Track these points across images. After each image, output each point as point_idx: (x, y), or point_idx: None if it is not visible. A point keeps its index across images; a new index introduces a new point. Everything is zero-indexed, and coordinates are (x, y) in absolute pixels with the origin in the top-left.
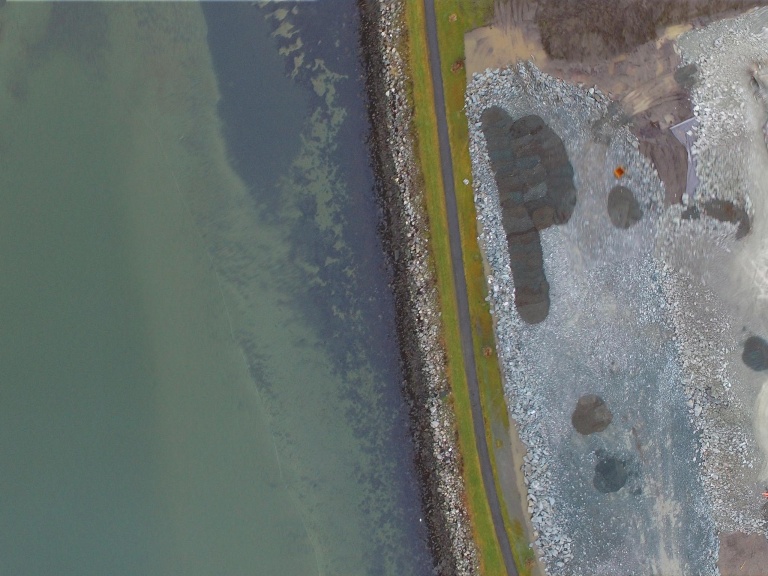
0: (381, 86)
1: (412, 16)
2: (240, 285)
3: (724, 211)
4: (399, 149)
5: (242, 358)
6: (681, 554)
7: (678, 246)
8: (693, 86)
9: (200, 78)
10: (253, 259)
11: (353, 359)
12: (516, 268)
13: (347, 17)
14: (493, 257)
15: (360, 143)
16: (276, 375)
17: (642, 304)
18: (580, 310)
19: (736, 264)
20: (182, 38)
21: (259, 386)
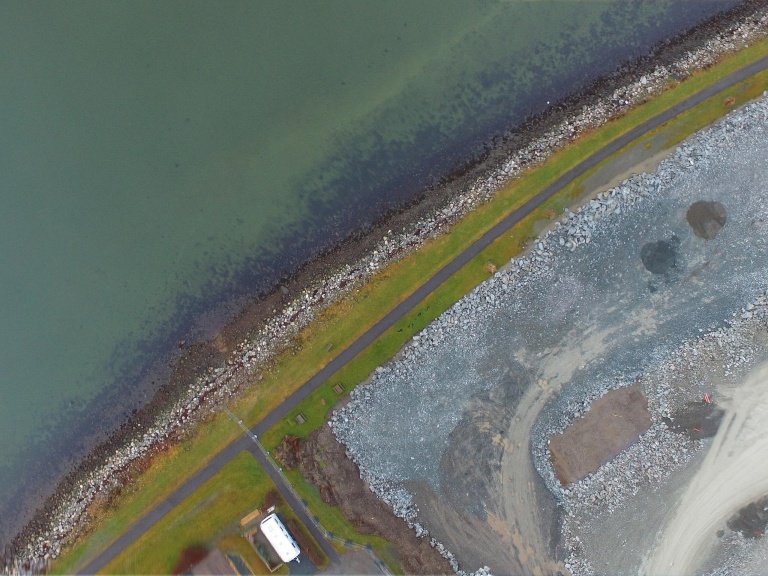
0: None
1: None
2: None
3: None
4: None
5: None
6: (610, 350)
7: None
8: None
9: None
10: None
11: None
12: None
13: None
14: None
15: None
16: None
17: None
18: None
19: None
20: None
21: None
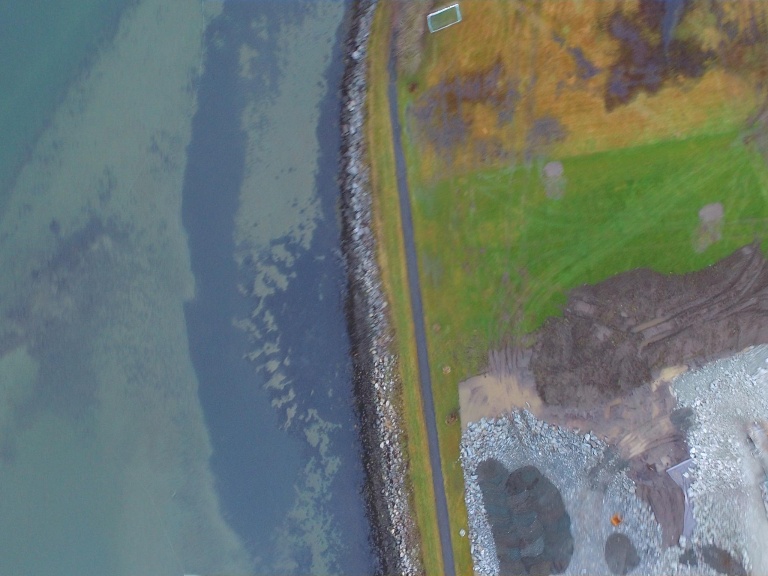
0: (375, 437)
1: (405, 369)
2: None
3: (722, 563)
4: (394, 501)
5: None
6: None
7: None
8: (689, 428)
9: (191, 433)
10: None
11: None
12: None
13: (340, 366)
14: None
15: (355, 493)
16: None
17: None
18: None
19: None
20: (172, 394)
21: None
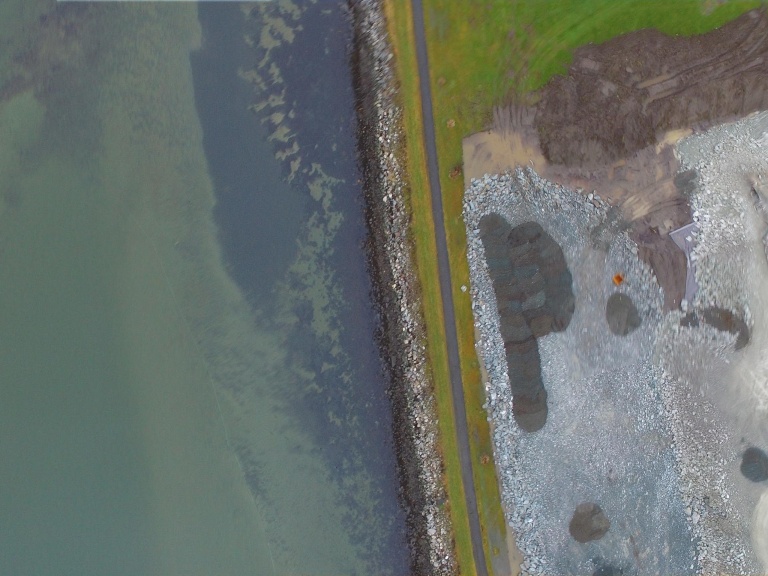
0: (378, 191)
1: (410, 121)
2: (235, 392)
3: (723, 320)
4: (396, 255)
5: (237, 466)
6: None
7: (677, 354)
8: (693, 191)
9: (195, 183)
10: (249, 365)
11: (349, 465)
12: (514, 376)
13: (344, 121)
14: (491, 365)
15: (357, 248)
16: (272, 482)
17: (640, 411)
18: (578, 418)
19: (735, 375)
20: (177, 142)
21: (254, 494)
